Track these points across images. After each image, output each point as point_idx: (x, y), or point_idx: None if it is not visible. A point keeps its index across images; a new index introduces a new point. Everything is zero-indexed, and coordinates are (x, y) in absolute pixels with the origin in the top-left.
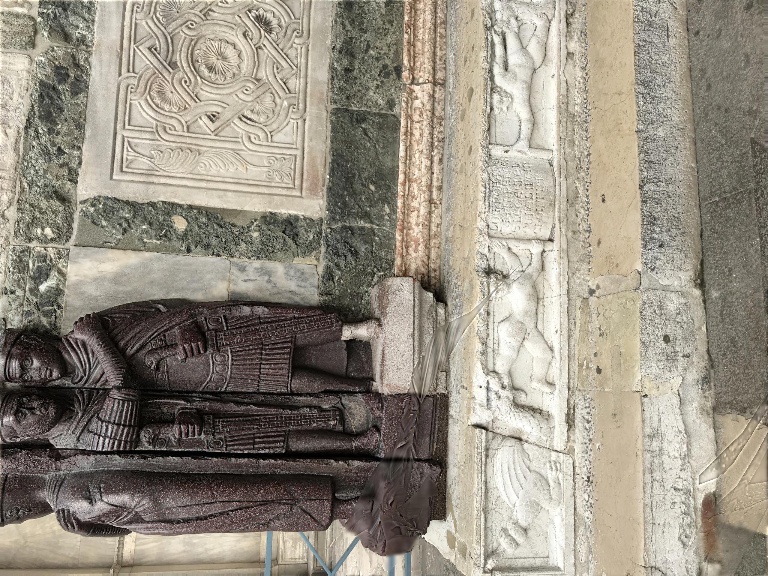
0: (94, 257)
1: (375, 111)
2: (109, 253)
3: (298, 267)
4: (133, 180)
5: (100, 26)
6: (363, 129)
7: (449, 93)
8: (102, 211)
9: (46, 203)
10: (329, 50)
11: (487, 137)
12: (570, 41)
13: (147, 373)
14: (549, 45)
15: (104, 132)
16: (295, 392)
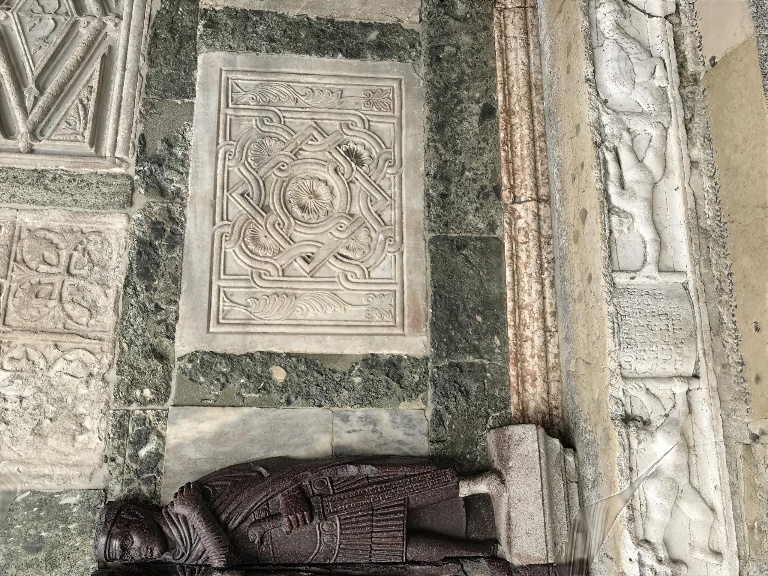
0: (193, 417)
1: (476, 235)
2: (208, 411)
3: (405, 413)
4: (230, 331)
5: (194, 177)
6: (465, 256)
7: (556, 210)
8: (200, 367)
9: (144, 363)
10: (423, 176)
11: (609, 264)
12: (692, 149)
13: (250, 547)
14: (668, 155)
15: (200, 284)
16: (410, 560)
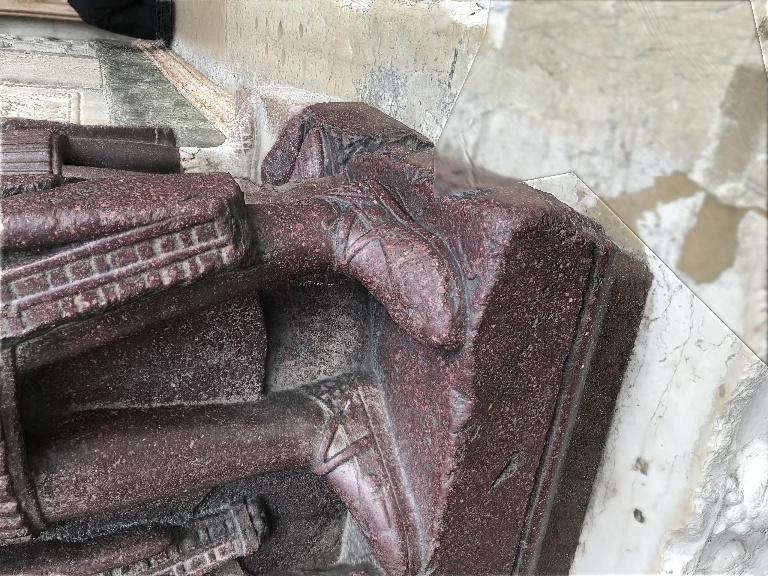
0: None
1: None
2: None
3: None
4: None
5: None
6: None
7: None
8: None
9: None
10: None
11: None
12: None
13: None
14: None
15: None
16: None
